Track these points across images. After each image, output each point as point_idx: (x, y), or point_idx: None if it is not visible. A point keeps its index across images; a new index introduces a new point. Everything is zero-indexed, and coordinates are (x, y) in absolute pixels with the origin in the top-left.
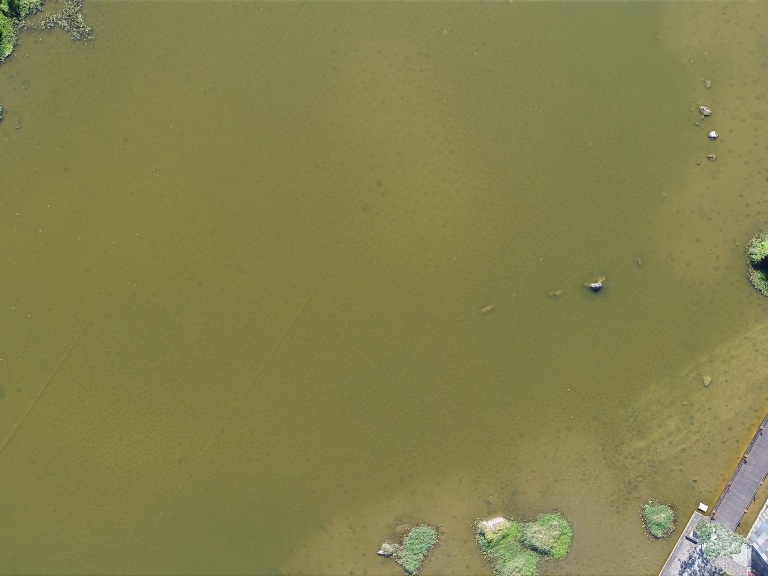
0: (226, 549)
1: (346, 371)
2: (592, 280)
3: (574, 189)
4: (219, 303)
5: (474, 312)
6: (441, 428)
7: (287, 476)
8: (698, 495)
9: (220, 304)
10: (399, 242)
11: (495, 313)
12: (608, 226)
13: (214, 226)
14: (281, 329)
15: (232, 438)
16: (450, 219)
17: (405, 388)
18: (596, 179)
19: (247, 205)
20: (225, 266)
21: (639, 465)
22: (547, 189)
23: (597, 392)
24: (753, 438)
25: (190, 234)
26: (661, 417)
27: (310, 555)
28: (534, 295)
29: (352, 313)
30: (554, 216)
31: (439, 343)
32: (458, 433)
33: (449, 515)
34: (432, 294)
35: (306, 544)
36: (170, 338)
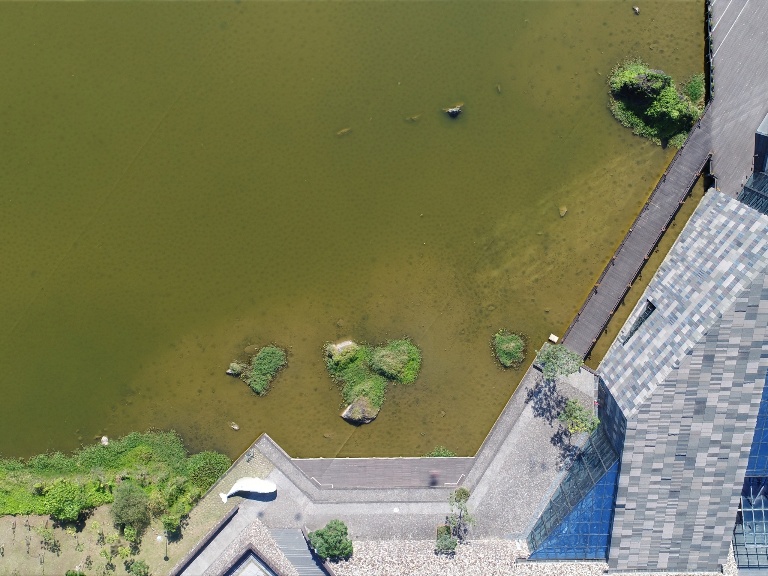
0: (76, 363)
1: (200, 190)
2: (450, 106)
3: (435, 12)
4: (75, 117)
5: (330, 134)
6: (293, 250)
7: (138, 293)
8: (549, 326)
9: (76, 118)
10: (257, 61)
11: (351, 136)
12: (468, 51)
13: (72, 39)
14: (136, 146)
15: (85, 253)
16: (309, 39)
17: (259, 209)
18: (458, 3)
19: (105, 19)
20: (82, 80)
21: (491, 294)
22: (408, 11)
23: (451, 219)
24: (605, 268)
25: (47, 47)
26: (515, 246)
27: (159, 372)
28: (391, 119)
29: (207, 132)
30: (414, 39)
31: (294, 165)
32: (310, 256)
33: (299, 337)
34: (288, 115)
35: (156, 361)
36: (25, 151)
